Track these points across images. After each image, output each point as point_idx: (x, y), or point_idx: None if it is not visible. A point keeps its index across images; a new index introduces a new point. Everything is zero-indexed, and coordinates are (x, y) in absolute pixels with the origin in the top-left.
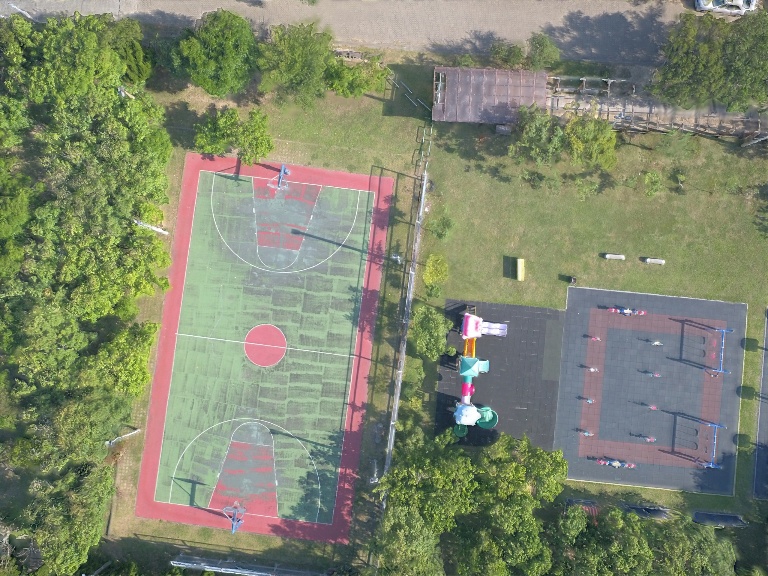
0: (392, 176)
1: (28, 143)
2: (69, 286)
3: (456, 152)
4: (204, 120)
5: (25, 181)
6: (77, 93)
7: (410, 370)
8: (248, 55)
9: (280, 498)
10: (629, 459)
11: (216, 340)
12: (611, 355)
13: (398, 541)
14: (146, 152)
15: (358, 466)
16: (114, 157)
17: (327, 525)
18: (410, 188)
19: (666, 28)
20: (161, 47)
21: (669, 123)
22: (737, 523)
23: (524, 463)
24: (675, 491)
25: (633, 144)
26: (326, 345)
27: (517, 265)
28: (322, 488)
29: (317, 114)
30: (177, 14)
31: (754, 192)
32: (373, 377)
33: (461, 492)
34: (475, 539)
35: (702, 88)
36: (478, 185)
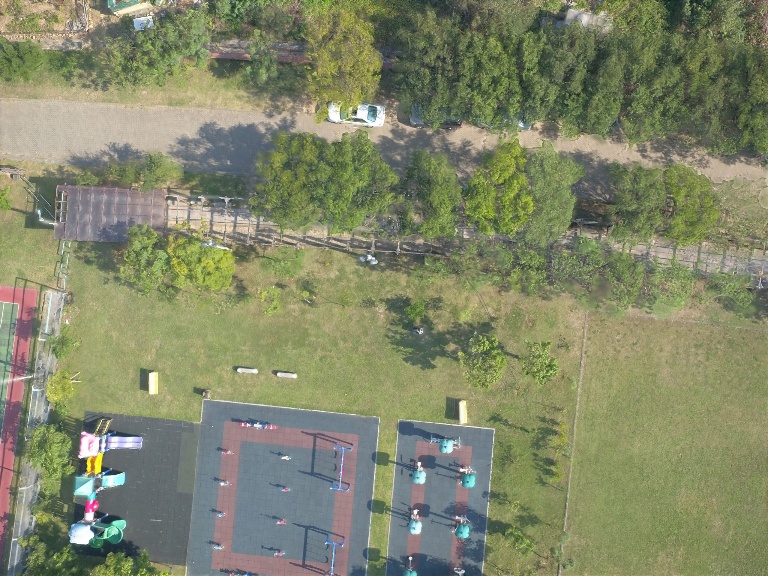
0: (36, 288)
1: None
2: None
3: (96, 265)
4: None
5: None
6: None
7: (50, 481)
8: None
9: None
10: (260, 571)
11: None
12: (244, 468)
13: None
14: None
15: None
16: None
17: None
18: None
19: None
20: None
21: (303, 235)
22: None
23: None
24: None
25: (267, 257)
26: None
27: None
28: None
29: None
30: None
31: (382, 306)
32: (15, 488)
33: None
34: None
35: (294, 214)
36: (117, 297)
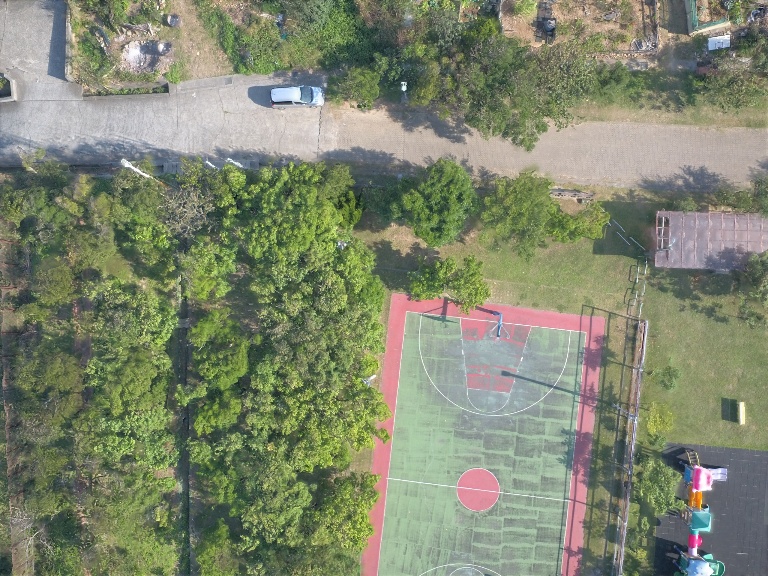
0: (603, 316)
1: (229, 283)
2: (286, 437)
3: (671, 291)
4: (409, 260)
5: (236, 330)
6: (300, 250)
7: None
8: (470, 206)
9: None
10: None
11: (428, 485)
12: None
13: None
14: (365, 305)
15: None
16: (334, 311)
17: None
18: (622, 328)
19: None
20: (376, 195)
21: None
22: None
23: None
24: None
25: None
26: (540, 489)
27: (739, 409)
28: None
29: None
30: (378, 151)
31: None
32: (589, 521)
33: None
34: None
35: None
36: (694, 325)
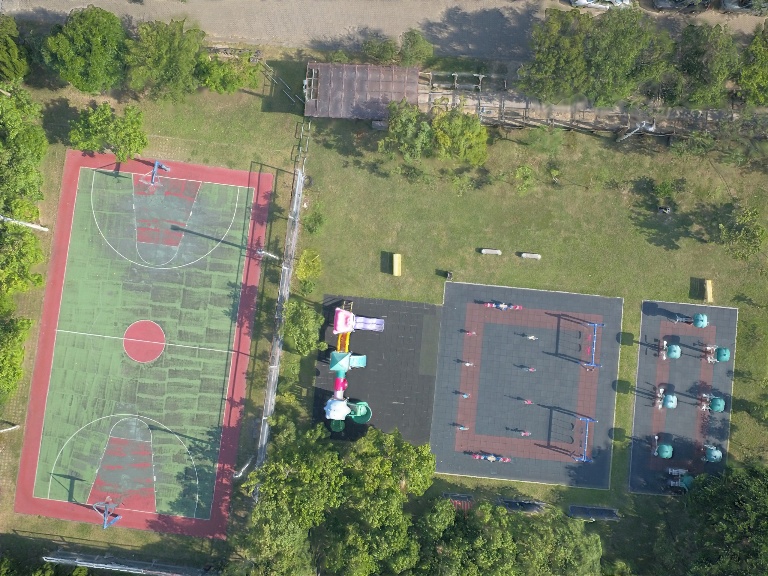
0: (271, 172)
1: None
2: None
3: (334, 148)
4: None
5: None
6: None
7: (288, 365)
8: (118, 51)
9: (158, 494)
10: (505, 453)
11: (95, 336)
12: (487, 350)
13: (263, 535)
14: (18, 148)
15: (236, 461)
16: None
17: (205, 520)
18: (289, 184)
19: (542, 24)
20: (35, 44)
21: (545, 118)
22: (612, 516)
23: (391, 457)
24: (550, 485)
25: (510, 139)
26: (205, 341)
27: (393, 260)
28: (200, 483)
29: (197, 110)
30: (58, 11)
31: (628, 187)
32: (251, 372)
33: (329, 486)
34: (344, 533)
35: (565, 83)
36: (356, 181)
